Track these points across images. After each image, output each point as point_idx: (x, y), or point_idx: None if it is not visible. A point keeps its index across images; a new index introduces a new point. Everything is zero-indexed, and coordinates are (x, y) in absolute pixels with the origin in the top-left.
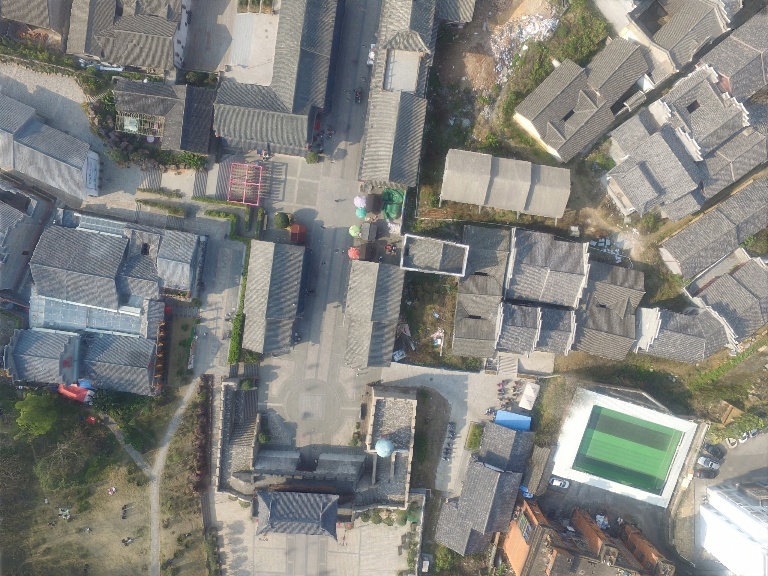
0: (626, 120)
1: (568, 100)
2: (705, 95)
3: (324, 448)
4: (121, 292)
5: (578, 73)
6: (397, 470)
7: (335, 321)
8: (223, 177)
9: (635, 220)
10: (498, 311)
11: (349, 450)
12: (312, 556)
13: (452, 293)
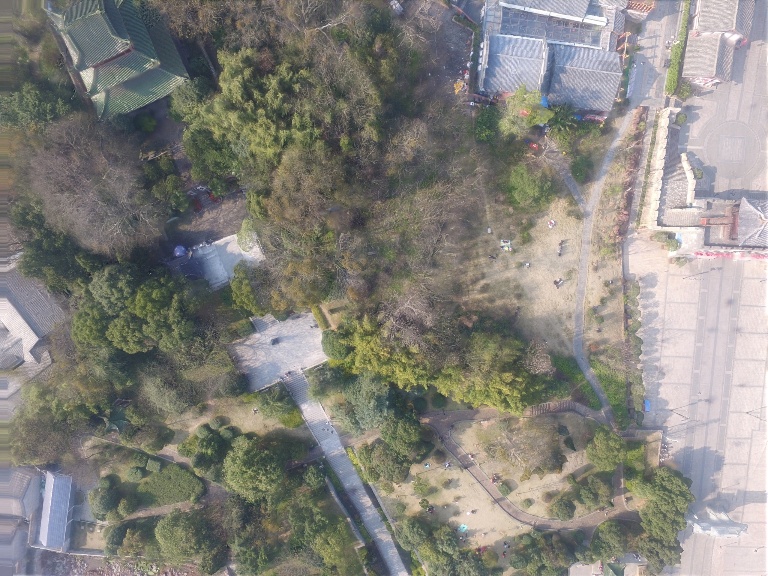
0: None
1: None
2: None
3: (742, 194)
4: None
5: None
6: None
7: (758, 60)
8: None
9: None
10: None
11: (767, 196)
12: (724, 311)
13: None
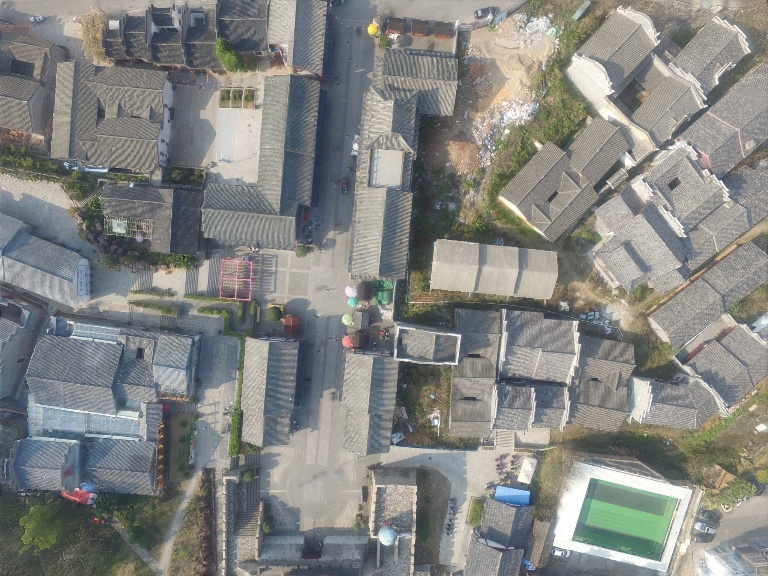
0: None
1: (552, 182)
2: (685, 172)
3: (328, 531)
4: (118, 397)
5: (560, 157)
6: (401, 552)
7: (332, 407)
8: (214, 272)
9: (623, 292)
10: (493, 392)
11: (353, 531)
12: None
13: (446, 374)
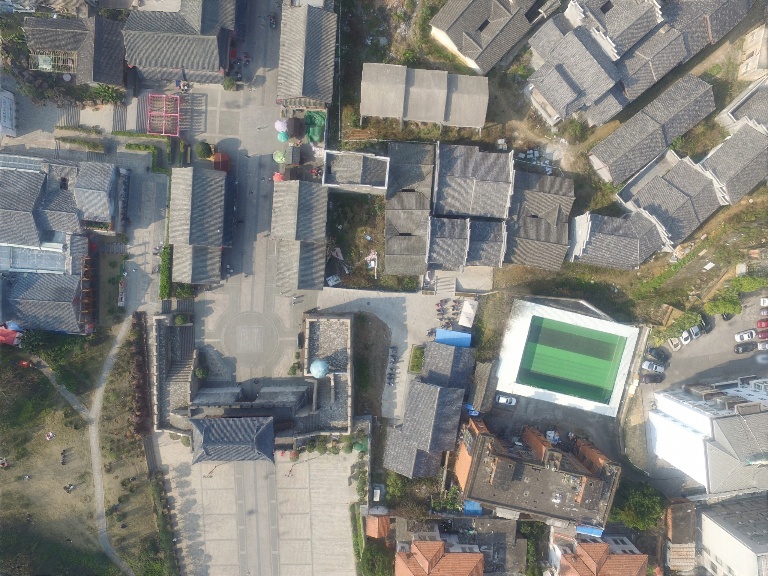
0: (542, 26)
1: (481, 9)
2: None
3: (265, 381)
4: (42, 229)
5: None
6: (338, 395)
7: (267, 250)
8: (143, 112)
9: (562, 129)
10: (427, 226)
11: (291, 382)
12: (262, 494)
13: (382, 213)
